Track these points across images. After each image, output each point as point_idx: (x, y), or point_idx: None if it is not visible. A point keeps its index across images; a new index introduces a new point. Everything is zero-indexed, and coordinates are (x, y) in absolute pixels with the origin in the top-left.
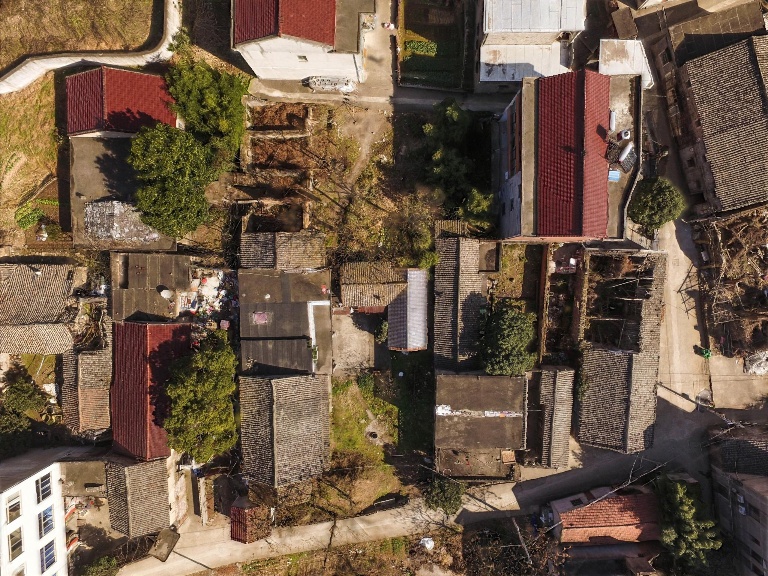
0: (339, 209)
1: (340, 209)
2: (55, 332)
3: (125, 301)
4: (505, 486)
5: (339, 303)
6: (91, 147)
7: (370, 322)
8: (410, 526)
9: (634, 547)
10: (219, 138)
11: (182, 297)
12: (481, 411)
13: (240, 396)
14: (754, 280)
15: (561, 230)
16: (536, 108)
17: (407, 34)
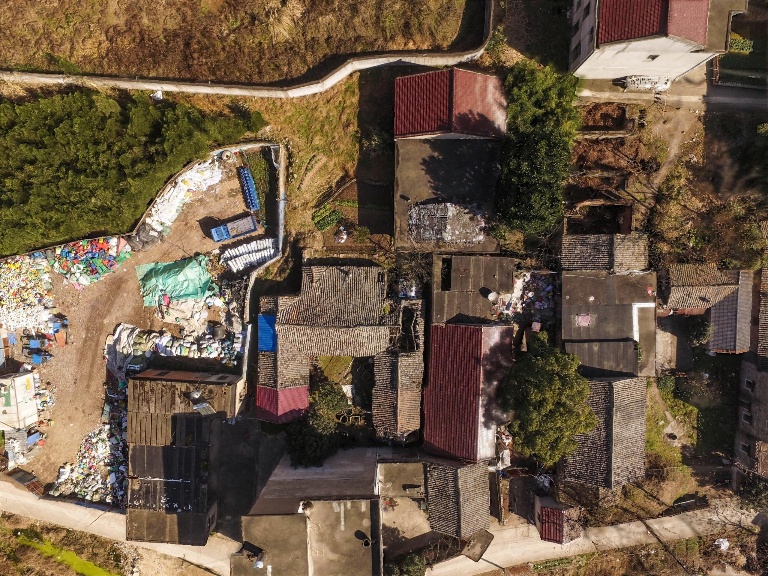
0: (644, 210)
1: (645, 210)
2: (375, 334)
3: (447, 303)
4: None
5: (664, 305)
6: (417, 149)
7: (674, 324)
8: (706, 527)
9: None
10: None
11: None
12: None
13: None
14: None
15: None
16: None
17: None
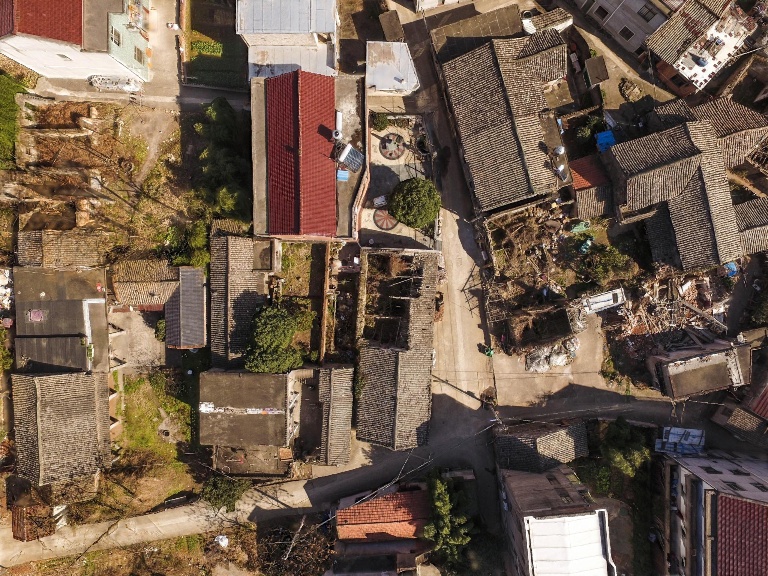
0: (129, 208)
1: (130, 208)
2: None
3: None
4: (297, 483)
5: (115, 301)
6: None
7: None
8: (204, 524)
9: (412, 543)
10: None
11: None
12: (243, 408)
13: (13, 394)
14: (533, 279)
15: (286, 228)
16: (265, 108)
17: (193, 34)
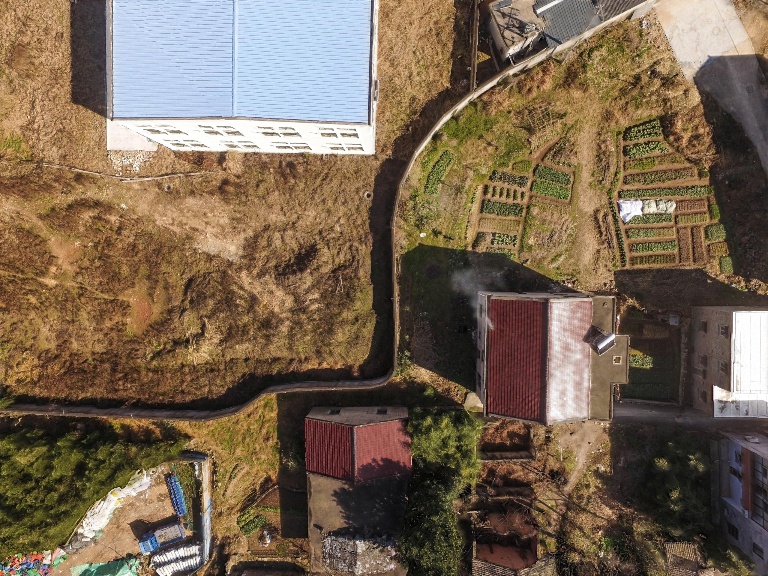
0: (556, 516)
1: (557, 516)
2: None
3: None
4: None
5: None
6: (328, 481)
7: None
8: None
9: None
10: (456, 477)
11: None
12: None
13: None
14: None
15: None
16: None
17: None
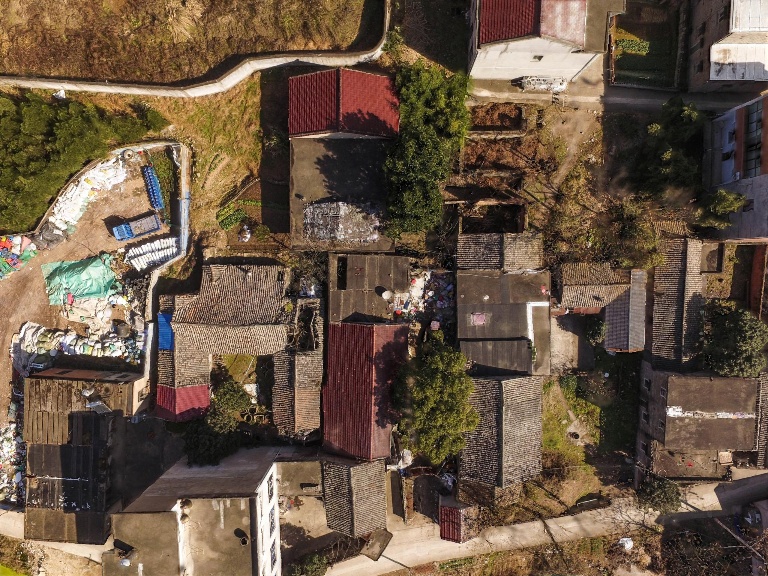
0: (545, 209)
1: (546, 209)
2: (272, 333)
3: (343, 302)
4: (707, 487)
5: (558, 304)
6: (312, 148)
7: (575, 323)
8: (610, 526)
9: None
10: None
11: (395, 298)
12: (713, 413)
13: None
14: None
15: None
16: None
17: (618, 33)
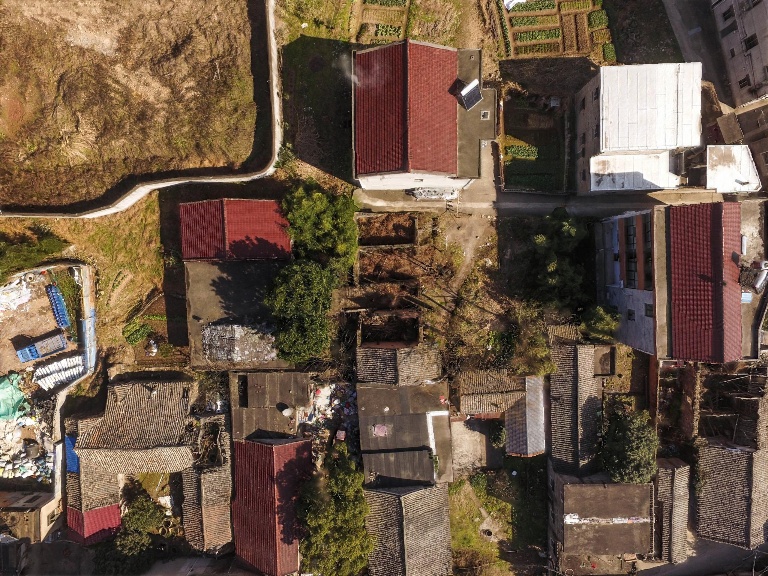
0: (446, 313)
1: (447, 313)
2: (177, 453)
3: (245, 420)
4: None
5: (457, 412)
6: (206, 271)
7: (481, 423)
8: None
9: None
10: (335, 258)
11: (299, 411)
12: (609, 518)
13: None
14: None
15: (699, 355)
16: (667, 235)
17: (507, 139)
